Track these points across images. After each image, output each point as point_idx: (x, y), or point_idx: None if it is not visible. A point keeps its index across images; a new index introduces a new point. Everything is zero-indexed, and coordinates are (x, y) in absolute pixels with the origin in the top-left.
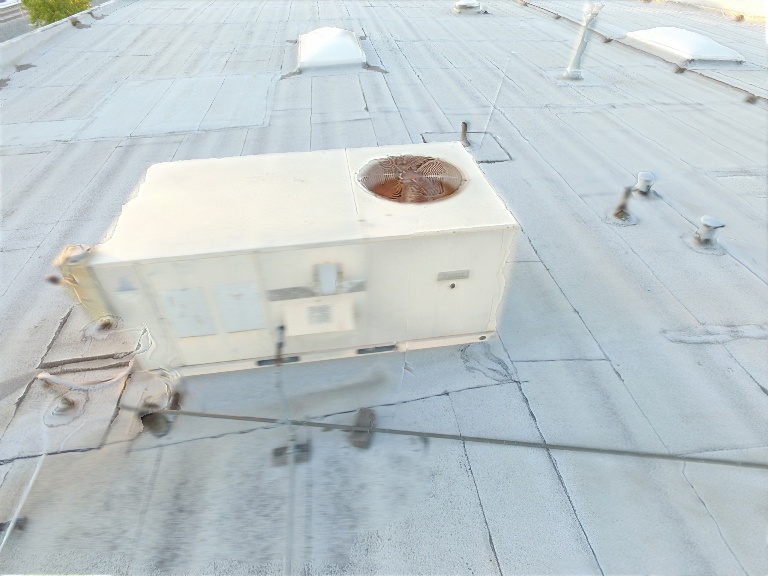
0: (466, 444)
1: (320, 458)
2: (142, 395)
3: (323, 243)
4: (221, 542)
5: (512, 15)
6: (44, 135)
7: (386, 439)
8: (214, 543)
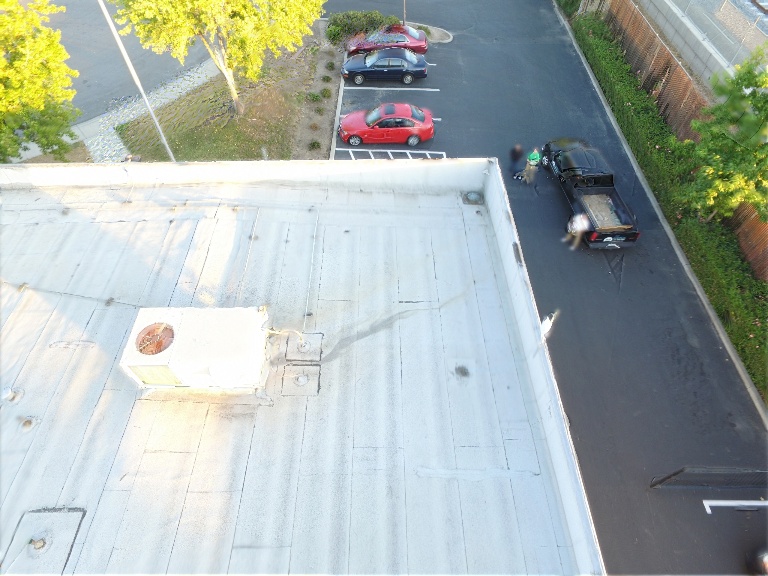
0: None
1: None
2: (279, 346)
3: None
4: None
5: None
6: None
7: None
8: None
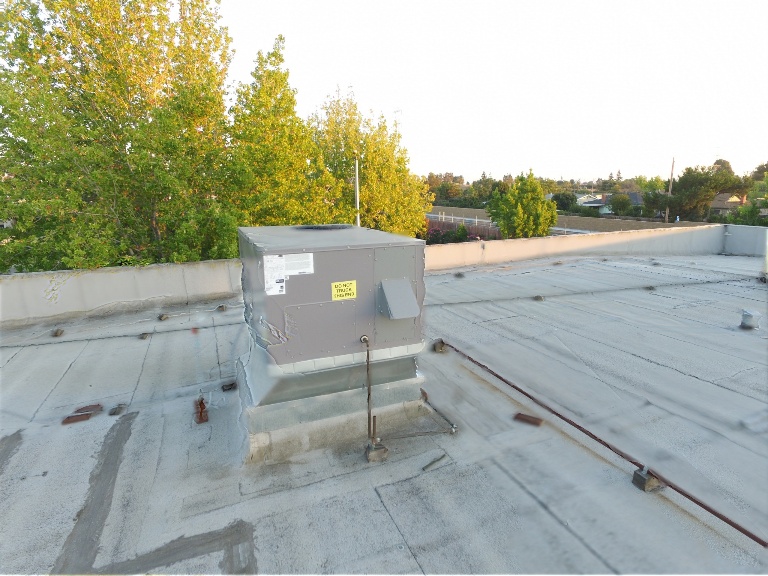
0: None
1: None
2: None
3: None
4: None
5: None
6: None
7: None
8: None
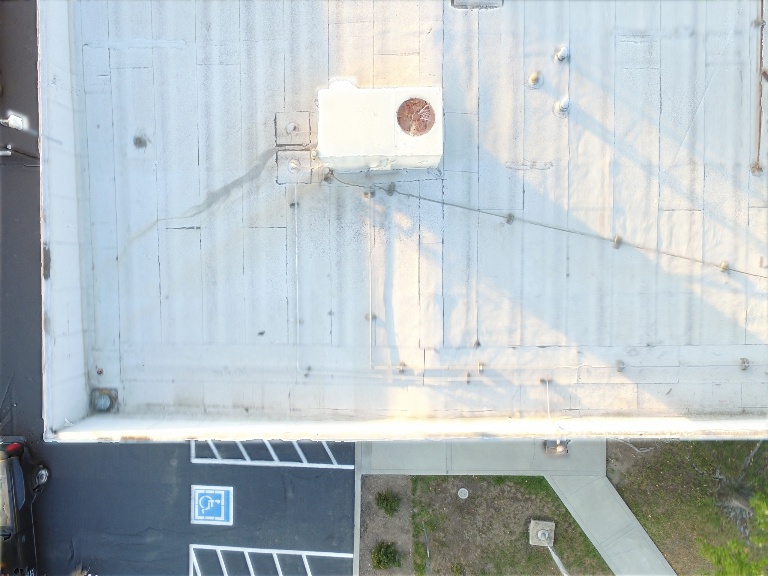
0: (420, 199)
1: (378, 197)
2: (318, 165)
3: (384, 156)
4: (352, 216)
5: None
6: None
7: (397, 195)
8: (350, 216)
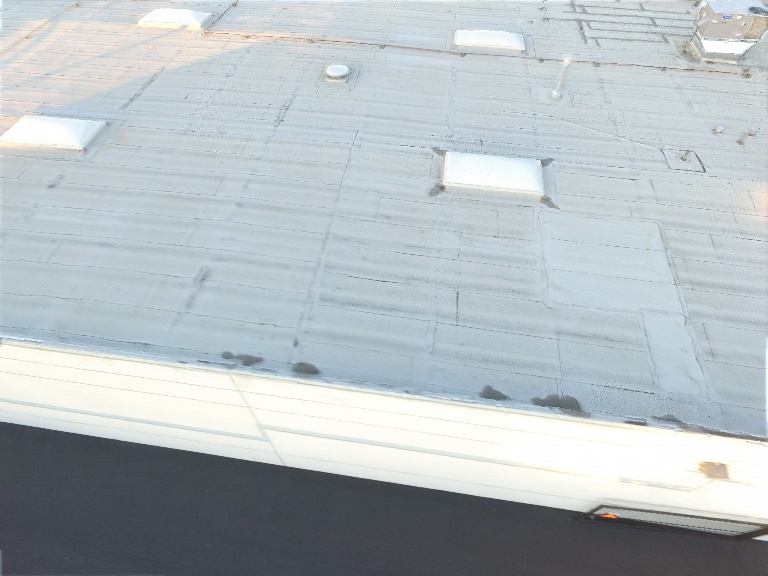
0: None
1: None
2: None
3: None
4: None
5: (358, 61)
6: (675, 333)
7: None
8: None
